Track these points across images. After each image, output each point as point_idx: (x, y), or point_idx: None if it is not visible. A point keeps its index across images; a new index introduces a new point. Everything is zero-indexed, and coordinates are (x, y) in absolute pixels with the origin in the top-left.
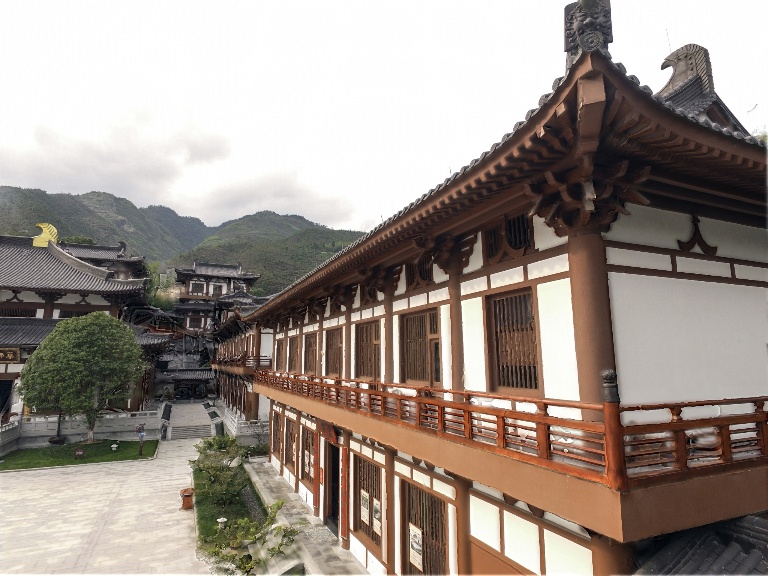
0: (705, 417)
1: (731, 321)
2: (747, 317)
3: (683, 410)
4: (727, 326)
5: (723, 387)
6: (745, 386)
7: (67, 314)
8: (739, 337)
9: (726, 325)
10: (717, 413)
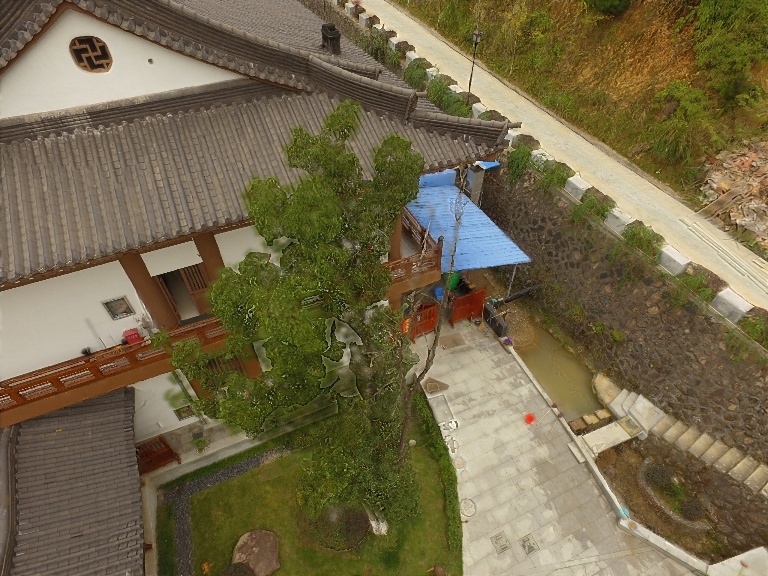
0: (33, 359)
1: (49, 303)
2: (70, 294)
3: (8, 362)
4: (45, 307)
5: (52, 339)
6: (79, 331)
7: None
8: (63, 308)
9: (44, 307)
10: (48, 353)
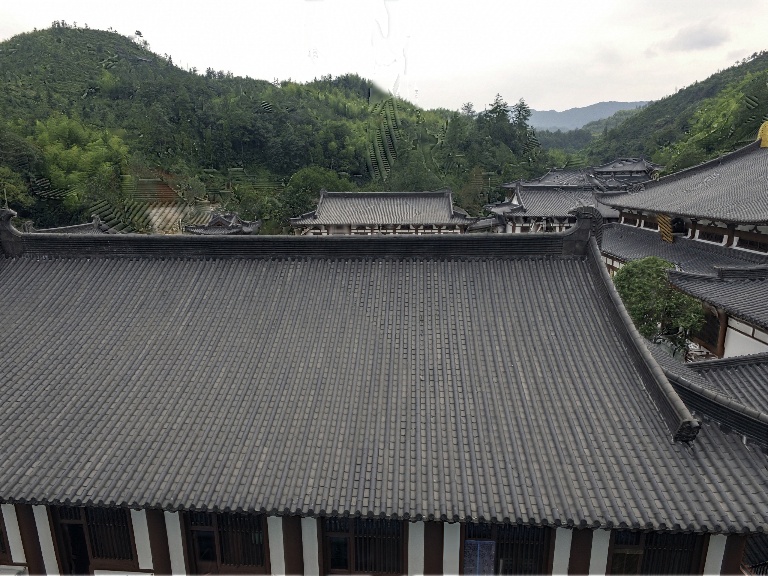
0: None
1: None
2: None
3: None
4: None
5: None
6: None
7: (744, 243)
8: None
9: None
10: None
